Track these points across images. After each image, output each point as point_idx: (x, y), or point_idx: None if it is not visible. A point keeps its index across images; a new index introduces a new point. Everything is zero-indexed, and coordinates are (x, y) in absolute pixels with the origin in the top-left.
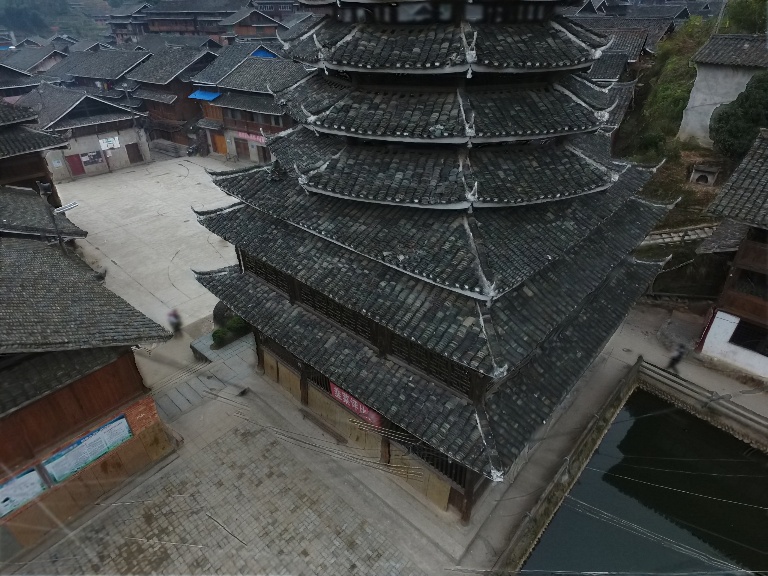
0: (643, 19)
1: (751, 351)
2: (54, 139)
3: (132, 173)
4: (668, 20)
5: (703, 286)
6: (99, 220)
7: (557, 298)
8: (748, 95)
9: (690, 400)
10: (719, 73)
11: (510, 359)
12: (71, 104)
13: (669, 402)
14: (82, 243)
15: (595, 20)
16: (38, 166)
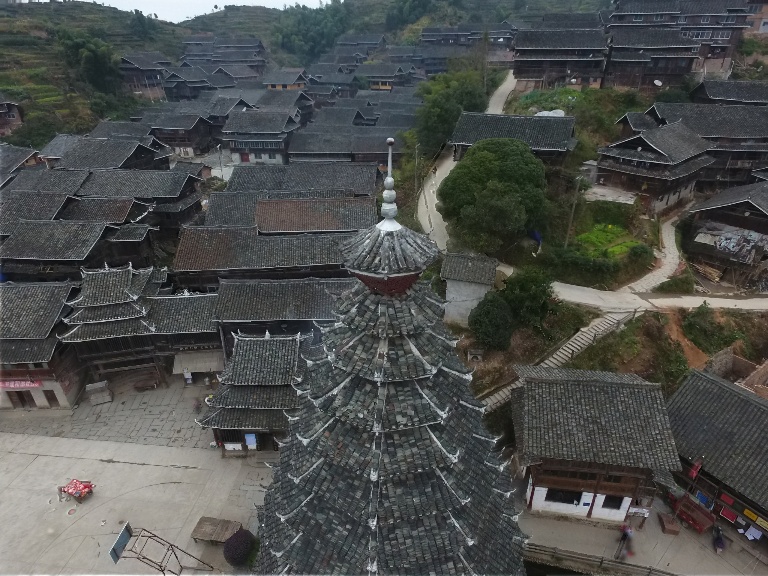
0: (355, 165)
1: (557, 503)
2: None
3: None
4: (374, 167)
5: (504, 440)
6: None
7: None
8: (488, 311)
9: (544, 557)
10: (461, 283)
11: None
12: None
13: (533, 562)
14: None
15: (318, 165)
16: None
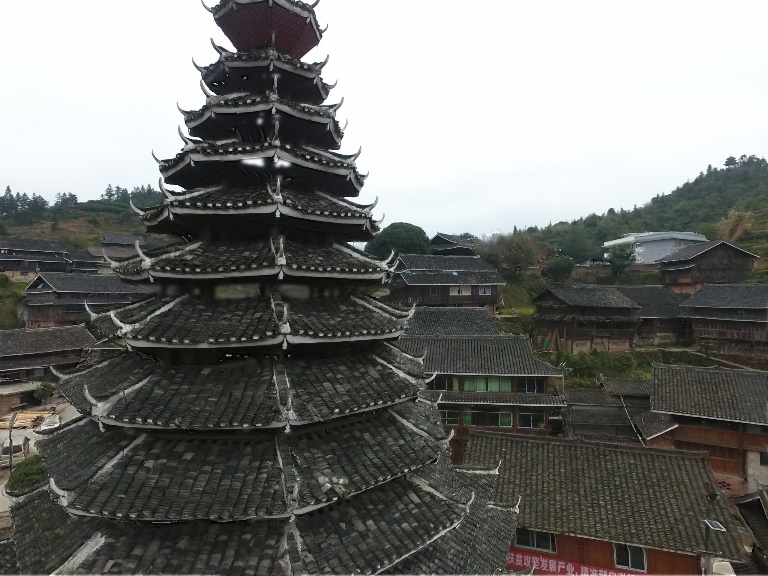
0: None
1: None
2: None
3: None
4: None
5: None
6: None
7: None
8: None
9: None
10: None
11: None
12: None
13: None
14: None
15: None
16: None
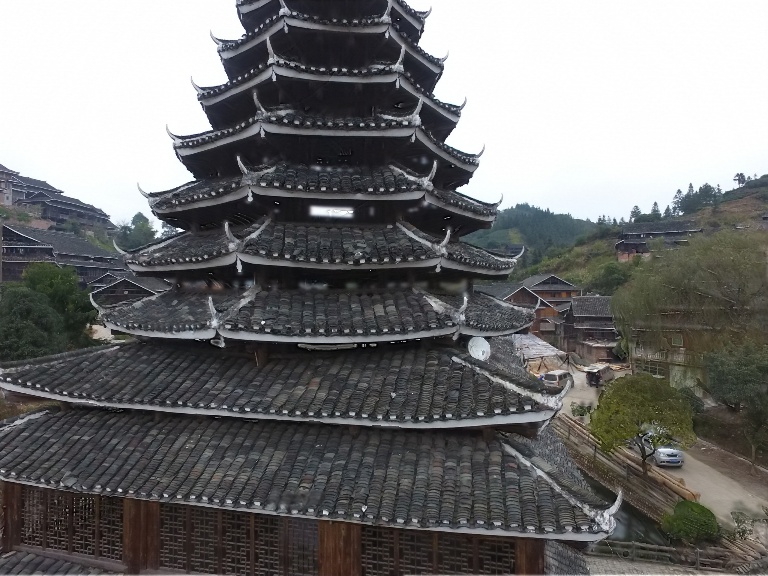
0: None
1: None
2: None
3: None
4: None
5: None
6: None
7: None
8: (28, 308)
9: None
10: None
11: None
12: None
13: None
14: None
15: None
16: None
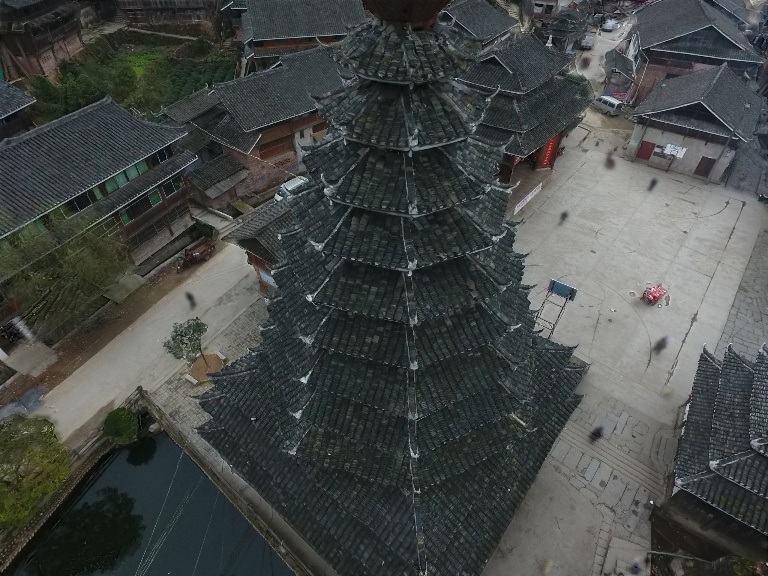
0: None
1: None
2: (519, 150)
3: (676, 183)
4: None
5: None
6: (568, 205)
7: (256, 443)
8: None
9: None
10: None
11: (206, 405)
12: (681, 103)
13: None
14: (529, 212)
15: None
16: (510, 159)
